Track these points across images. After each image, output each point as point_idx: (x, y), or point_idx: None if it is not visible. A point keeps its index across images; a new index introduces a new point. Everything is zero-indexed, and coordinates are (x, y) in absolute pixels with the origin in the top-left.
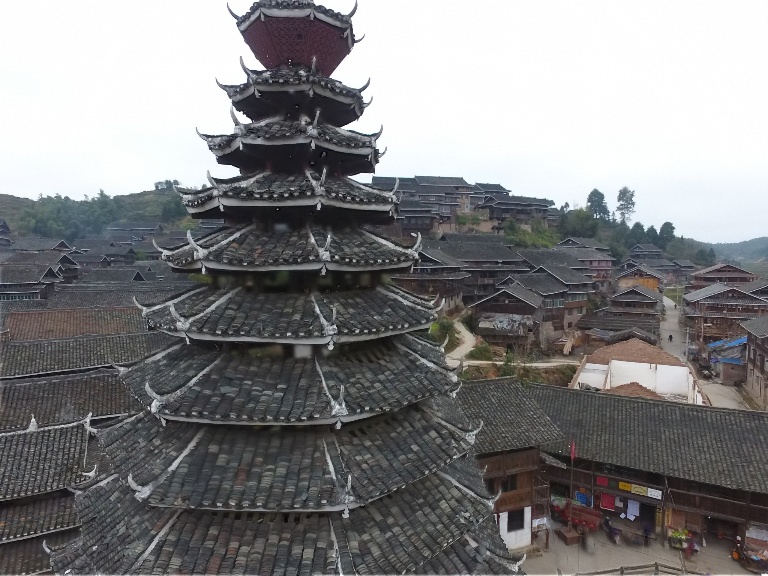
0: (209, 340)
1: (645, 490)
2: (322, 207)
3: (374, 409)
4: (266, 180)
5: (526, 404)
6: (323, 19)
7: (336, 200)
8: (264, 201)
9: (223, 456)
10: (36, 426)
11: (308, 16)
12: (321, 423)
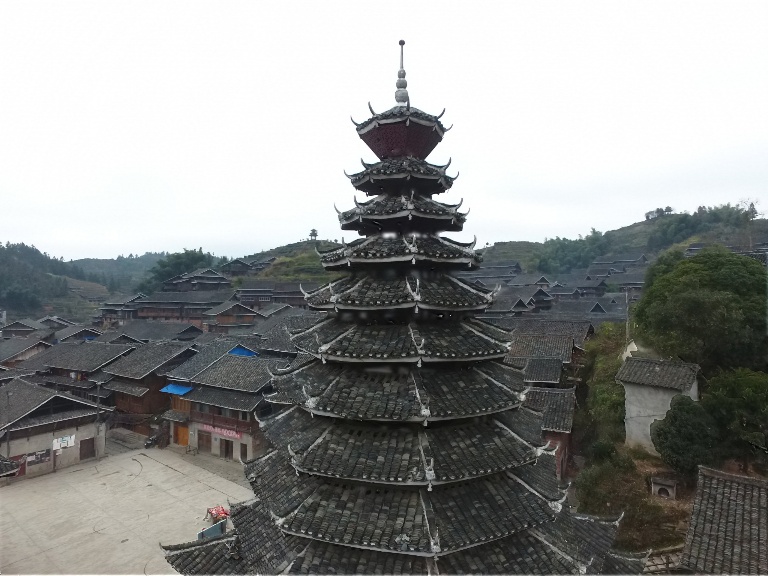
0: None
1: None
2: (352, 264)
3: (334, 411)
4: None
5: None
6: (386, 122)
7: (359, 258)
8: (331, 263)
9: (295, 420)
10: None
11: (375, 126)
12: (307, 410)
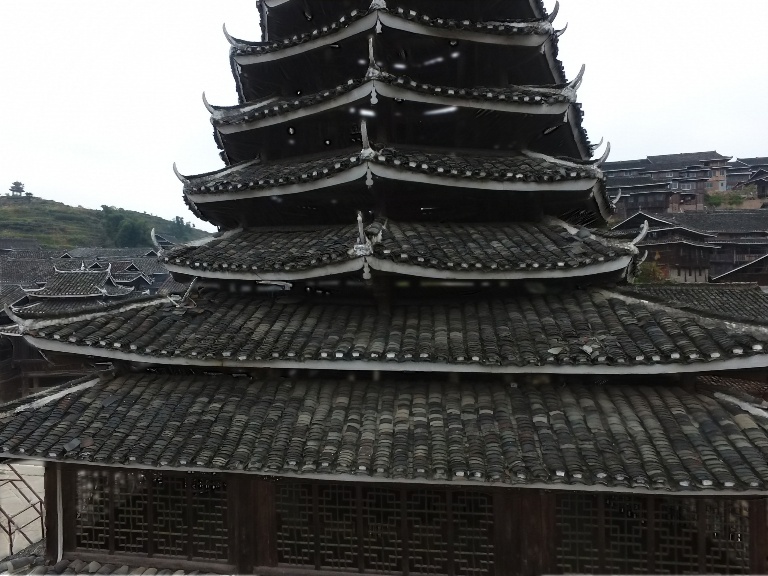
0: (282, 4)
1: None
2: None
3: (422, 17)
4: None
5: None
6: None
7: None
8: None
9: (286, 102)
10: None
11: None
12: (362, 30)
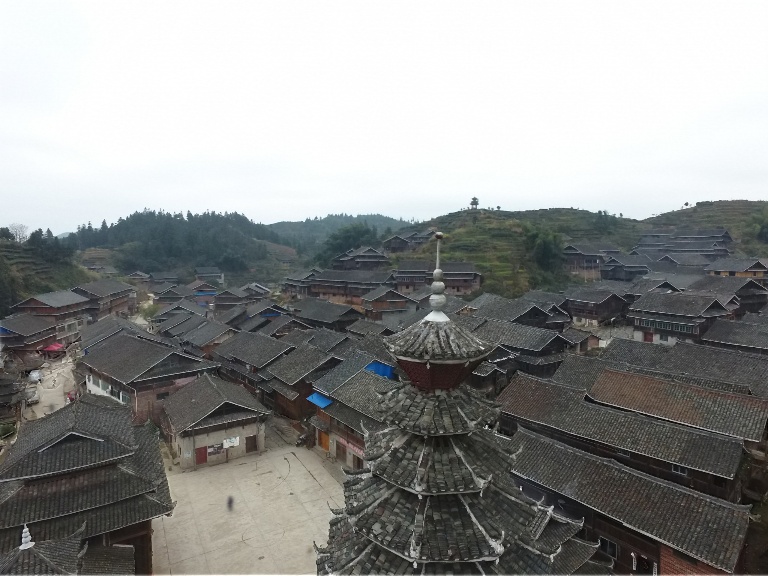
0: None
1: None
2: None
3: None
4: (375, 478)
5: None
6: (405, 359)
7: None
8: None
9: None
10: None
11: None
12: None
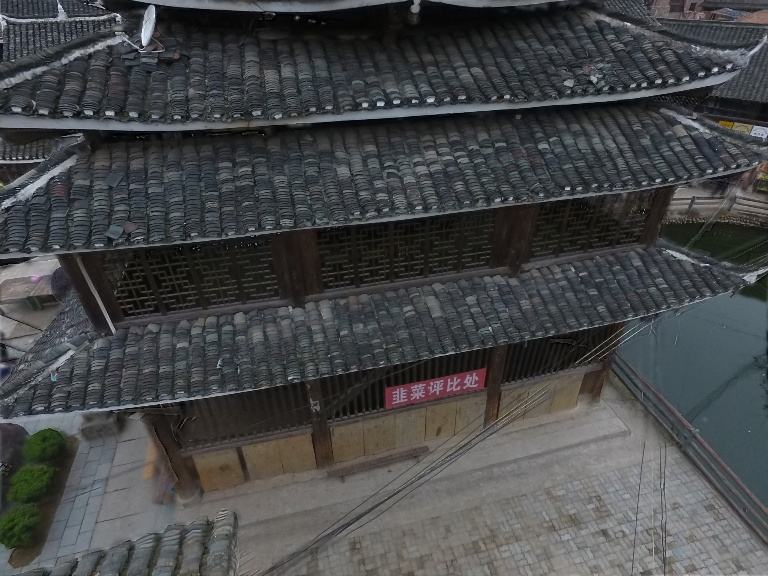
0: None
1: (749, 128)
2: None
3: None
4: None
5: (634, 9)
6: None
7: None
8: None
9: None
10: (65, 14)
11: None
12: None
